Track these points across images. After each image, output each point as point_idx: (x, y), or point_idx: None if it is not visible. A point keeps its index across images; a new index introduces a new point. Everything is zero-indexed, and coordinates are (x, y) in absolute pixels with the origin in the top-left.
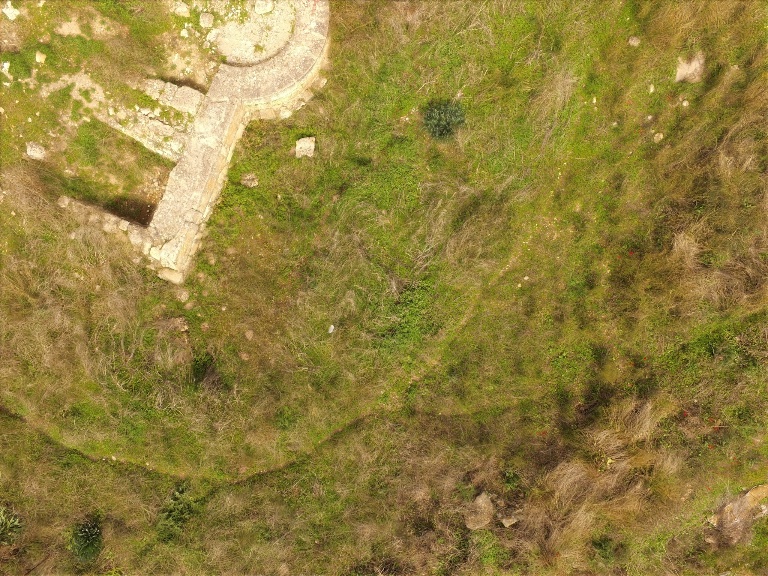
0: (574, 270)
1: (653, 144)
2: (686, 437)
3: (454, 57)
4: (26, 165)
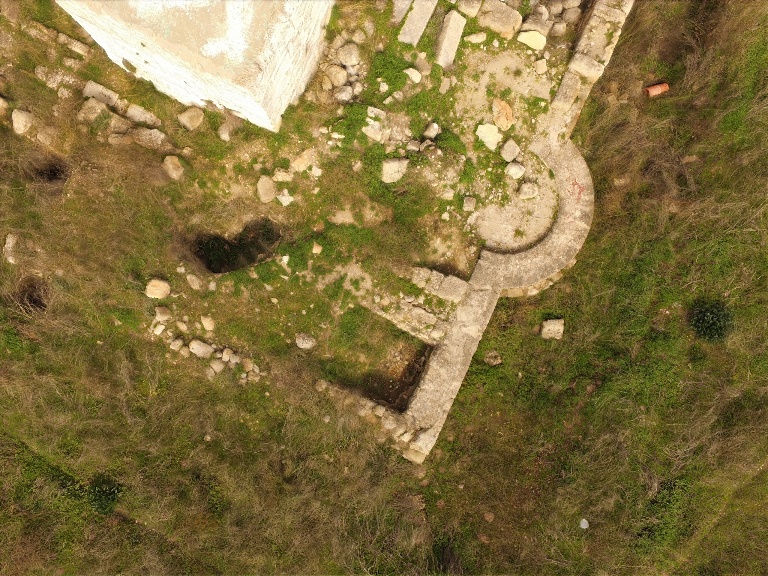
0: None
1: None
2: None
3: (725, 257)
4: (302, 361)
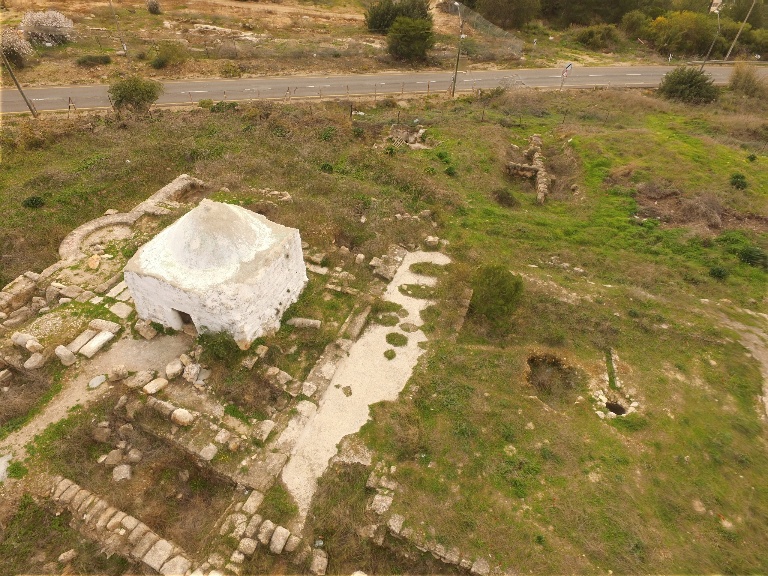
0: None
1: None
2: None
3: None
4: None
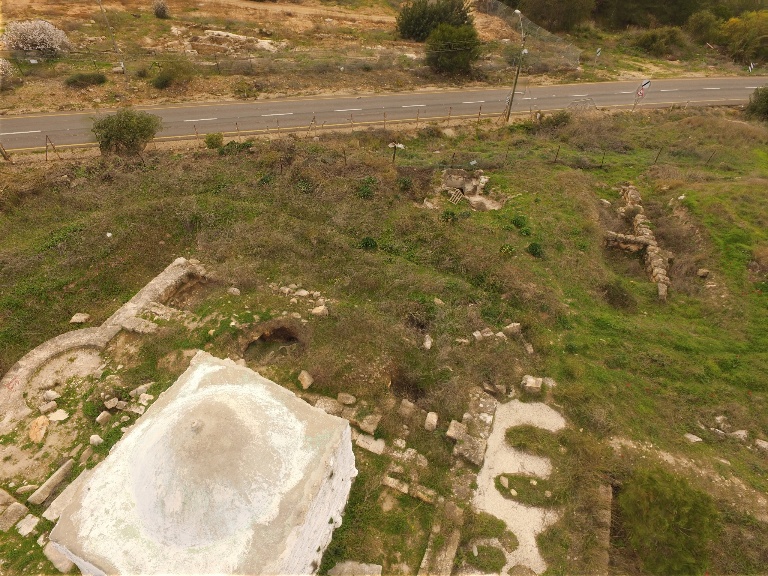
0: None
1: None
2: None
3: None
4: None
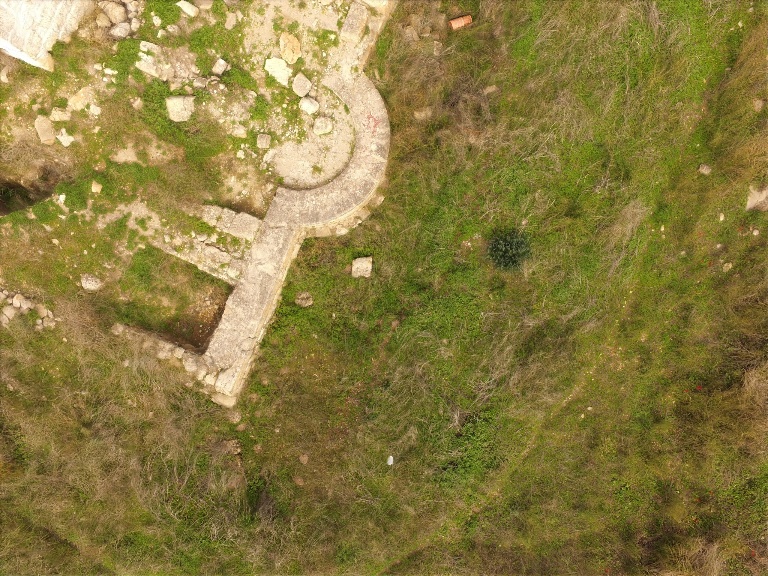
0: (639, 401)
1: (721, 273)
2: (752, 575)
3: (520, 184)
4: (82, 301)
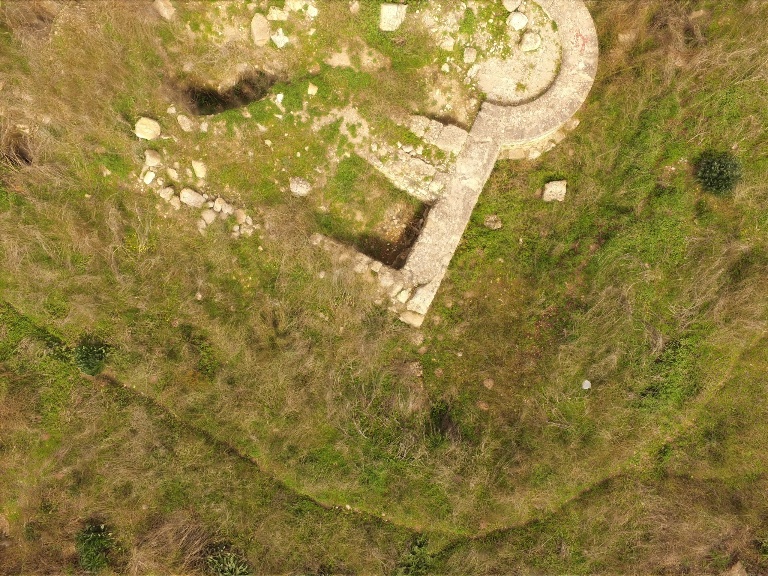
0: None
1: None
2: None
3: (732, 108)
4: (297, 203)
